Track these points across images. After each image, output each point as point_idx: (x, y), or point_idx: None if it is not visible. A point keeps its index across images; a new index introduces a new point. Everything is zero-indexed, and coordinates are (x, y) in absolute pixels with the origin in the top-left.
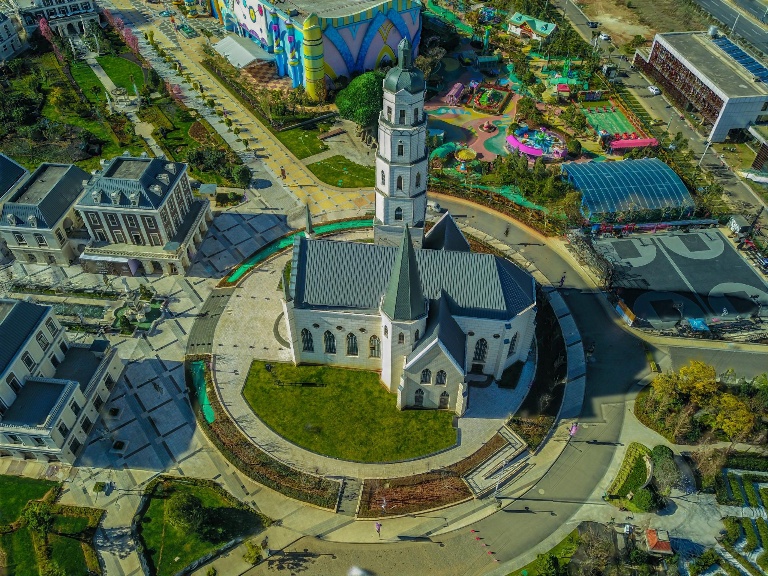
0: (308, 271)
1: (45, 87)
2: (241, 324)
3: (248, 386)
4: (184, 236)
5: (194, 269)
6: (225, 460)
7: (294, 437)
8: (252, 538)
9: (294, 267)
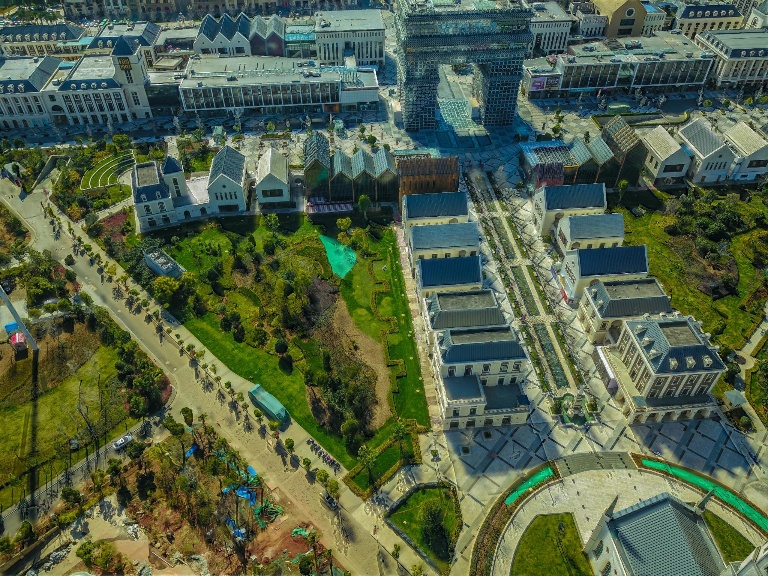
0: (644, 519)
1: (767, 221)
2: (602, 489)
3: (546, 518)
4: (661, 405)
5: (640, 428)
6: (480, 526)
7: (516, 572)
8: (431, 568)
9: (639, 505)
